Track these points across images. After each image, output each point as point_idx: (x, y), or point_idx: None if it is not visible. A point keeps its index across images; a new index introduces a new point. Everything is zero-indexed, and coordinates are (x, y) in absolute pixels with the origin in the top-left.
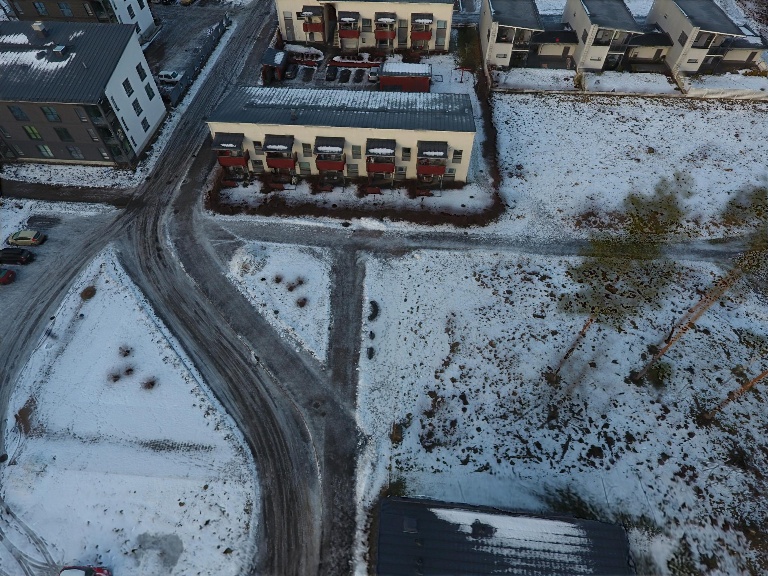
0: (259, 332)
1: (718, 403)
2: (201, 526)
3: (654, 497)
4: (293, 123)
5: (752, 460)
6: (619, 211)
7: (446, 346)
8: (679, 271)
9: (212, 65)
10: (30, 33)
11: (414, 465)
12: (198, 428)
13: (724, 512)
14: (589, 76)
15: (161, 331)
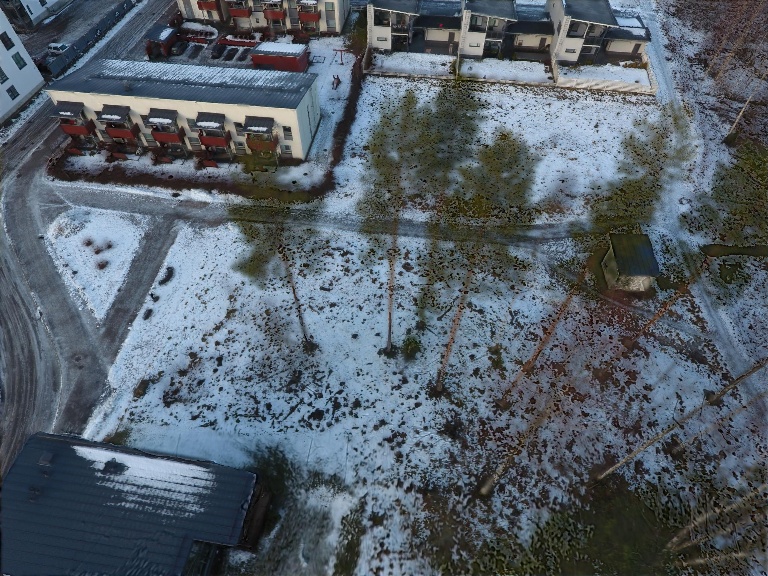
0: (52, 290)
1: (460, 378)
2: None
3: (354, 459)
4: (124, 94)
5: (466, 431)
6: (446, 194)
7: (223, 312)
8: (485, 254)
9: (108, 39)
10: None
11: (146, 417)
12: None
13: (414, 476)
14: (468, 62)
15: None
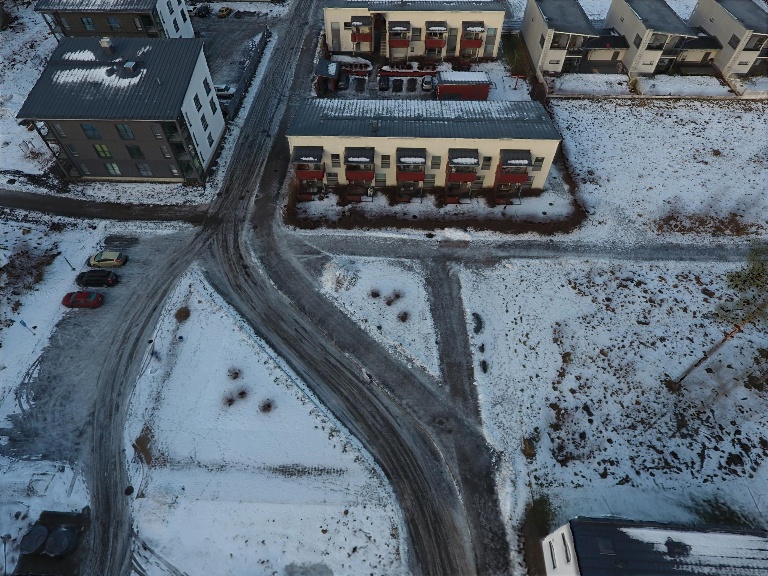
0: (366, 349)
1: None
2: (349, 554)
3: None
4: (376, 135)
5: None
6: (698, 214)
7: (558, 356)
8: None
9: (261, 77)
10: (96, 49)
11: (553, 480)
12: (325, 451)
13: None
14: (642, 80)
15: (266, 351)
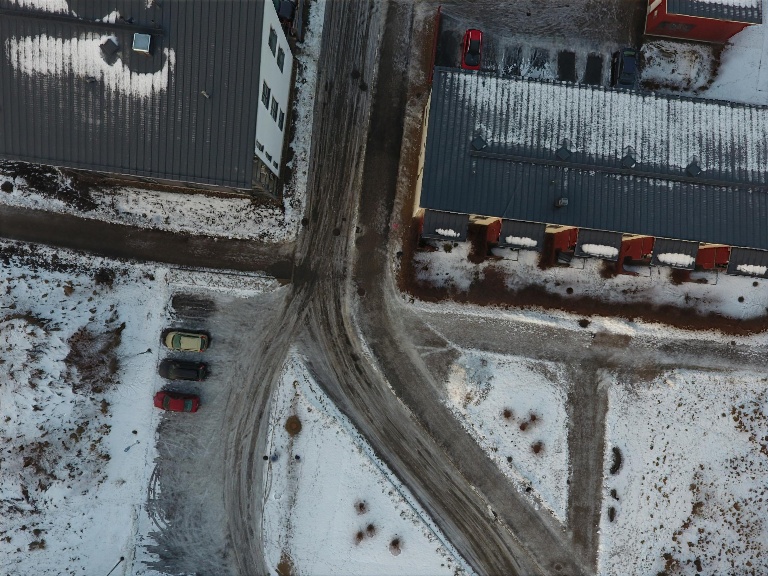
0: (494, 484)
1: None
2: None
3: None
4: (560, 220)
5: None
6: None
7: (689, 506)
8: None
9: None
10: None
11: None
12: None
13: None
14: None
15: (389, 479)
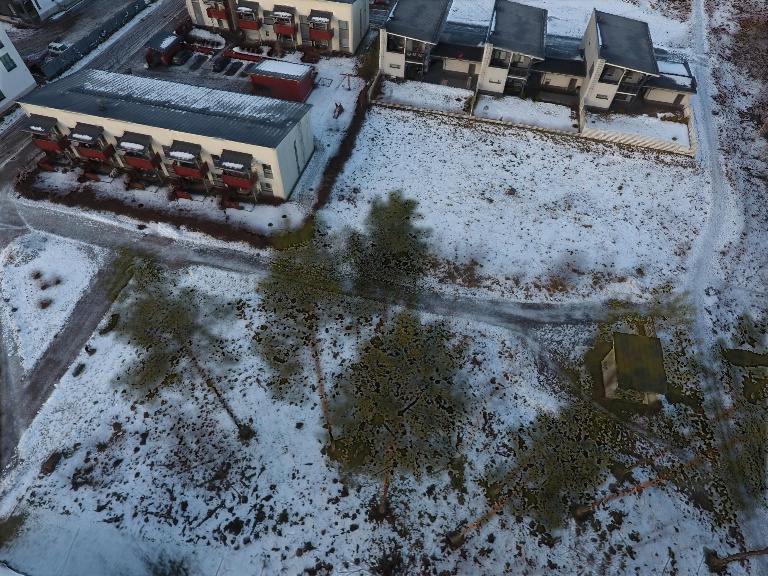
0: None
1: (410, 496)
2: None
3: None
4: (97, 114)
5: (403, 571)
6: (436, 255)
7: (161, 376)
8: (468, 334)
9: (112, 41)
10: None
11: (48, 501)
12: None
13: None
14: (486, 99)
15: None
